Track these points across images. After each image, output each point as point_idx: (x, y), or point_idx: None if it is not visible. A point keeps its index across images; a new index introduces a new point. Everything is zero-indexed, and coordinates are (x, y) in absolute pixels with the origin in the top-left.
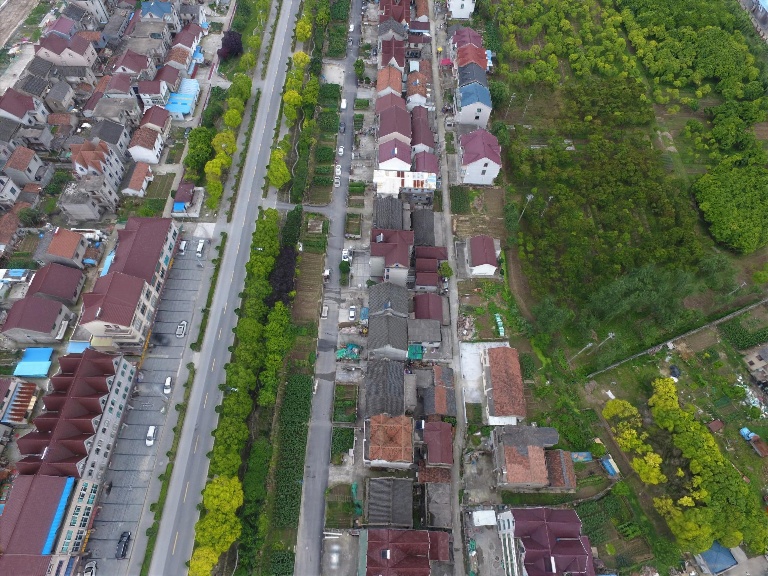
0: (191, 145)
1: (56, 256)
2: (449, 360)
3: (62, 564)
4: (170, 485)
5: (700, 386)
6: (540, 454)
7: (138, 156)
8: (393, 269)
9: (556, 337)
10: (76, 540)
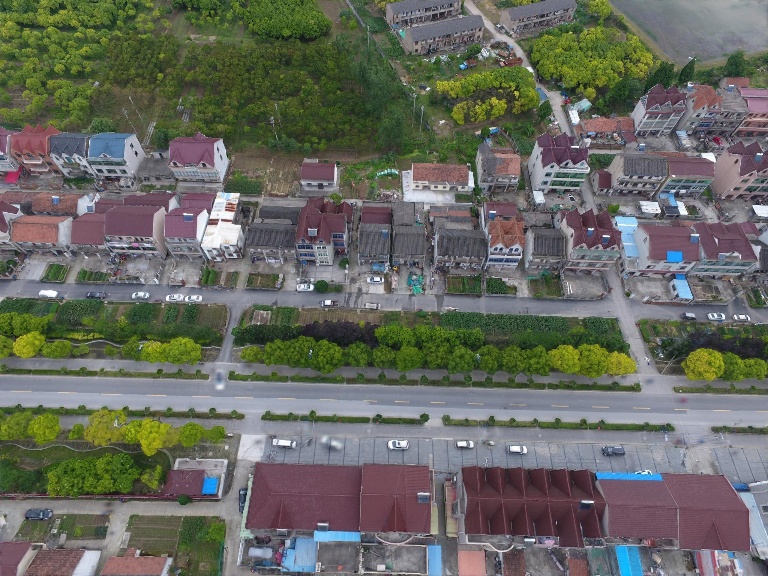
0: (93, 482)
1: None
2: None
3: None
4: None
5: (432, 78)
6: None
7: None
8: None
9: (407, 134)
10: None
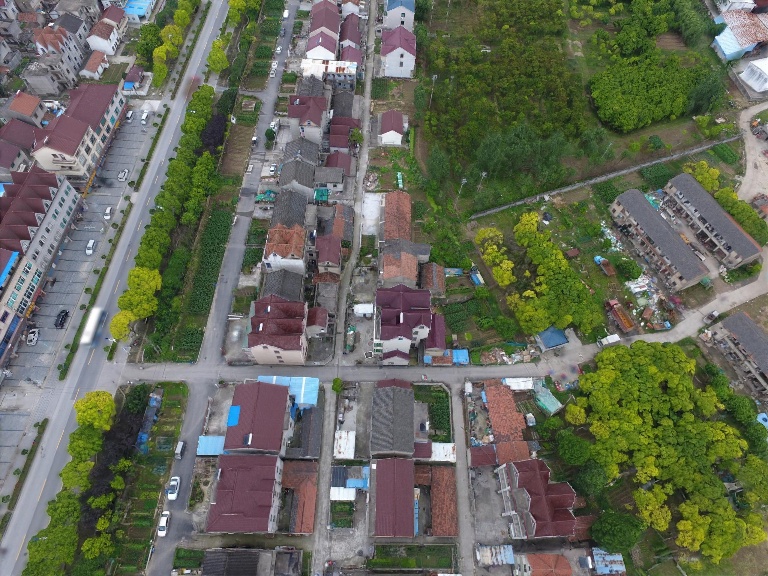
0: (142, 37)
1: (17, 113)
2: (351, 202)
3: (7, 315)
4: (104, 281)
5: (567, 227)
6: (413, 260)
7: (96, 47)
8: (306, 128)
9: (443, 183)
10: (21, 304)
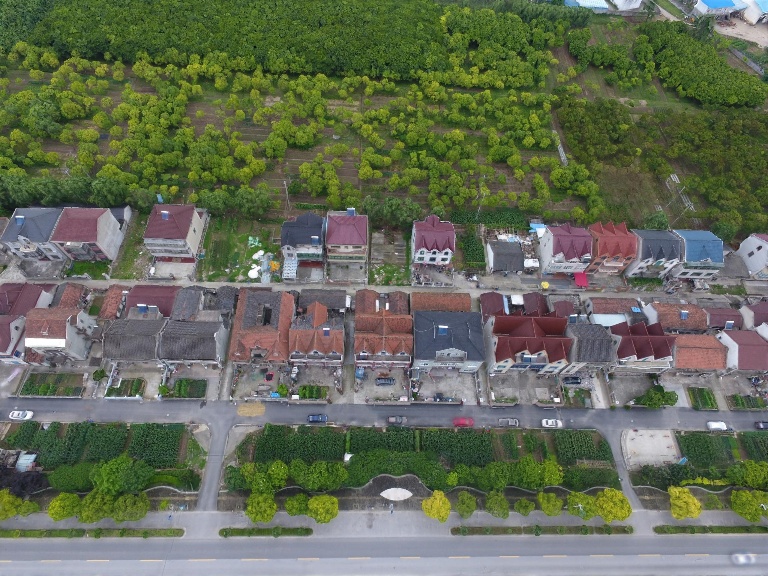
0: None
1: None
2: None
3: None
4: None
5: None
6: None
7: None
8: None
9: None
10: None
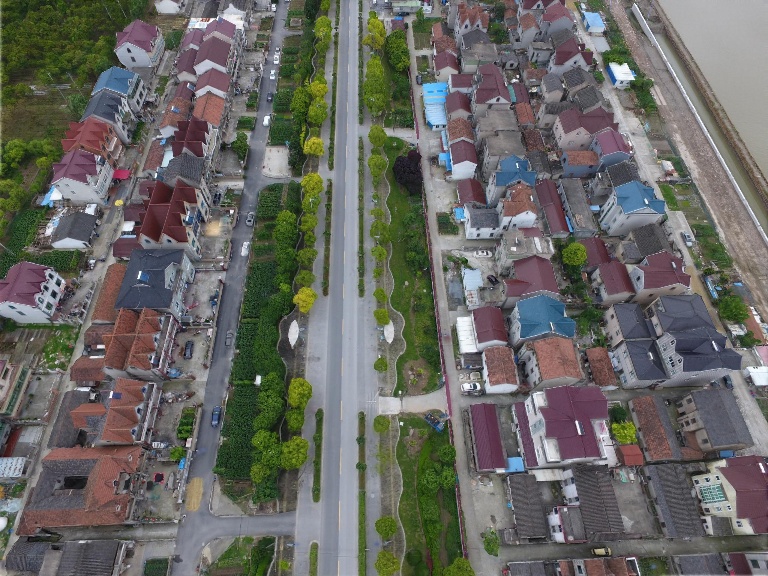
0: None
1: None
2: None
3: None
4: None
5: None
6: None
7: None
8: None
9: None
10: None
